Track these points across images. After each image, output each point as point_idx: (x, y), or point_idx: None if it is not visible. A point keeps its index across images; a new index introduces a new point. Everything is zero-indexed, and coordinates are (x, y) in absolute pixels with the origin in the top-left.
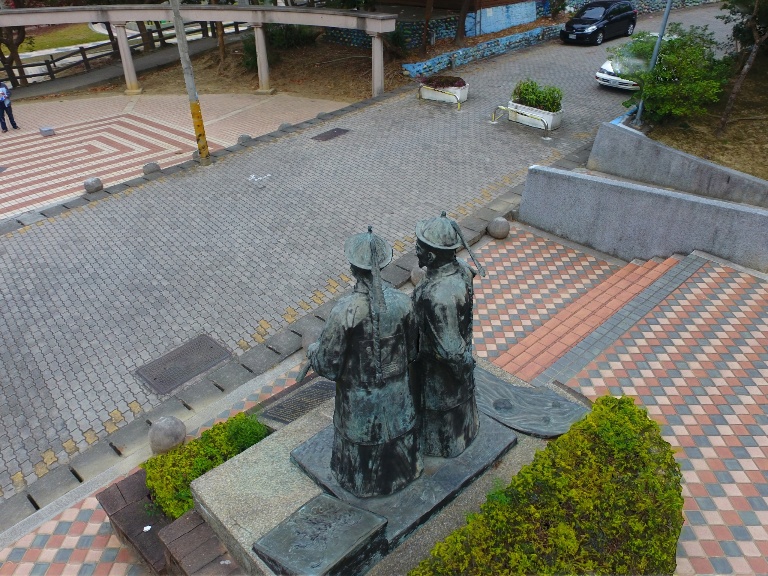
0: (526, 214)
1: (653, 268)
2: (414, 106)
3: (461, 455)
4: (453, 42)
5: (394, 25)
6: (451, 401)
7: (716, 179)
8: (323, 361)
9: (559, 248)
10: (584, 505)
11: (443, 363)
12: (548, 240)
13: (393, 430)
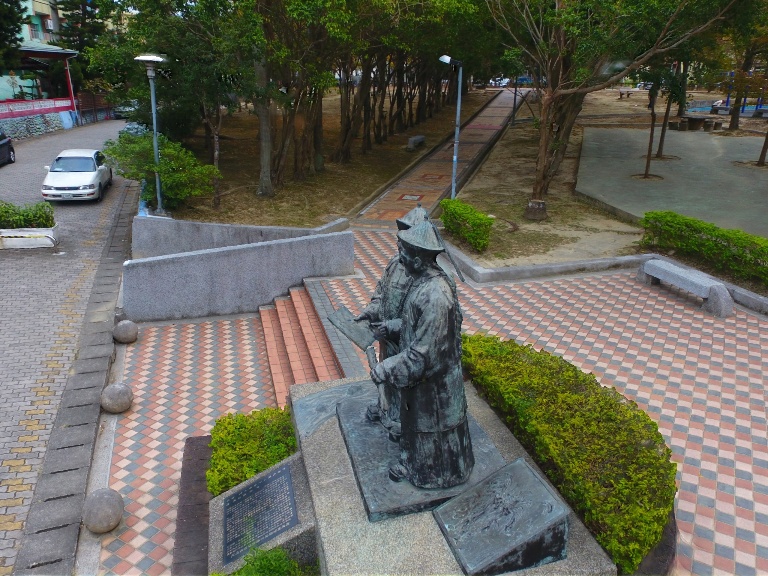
0: (135, 312)
1: (286, 304)
2: None
3: None
4: None
5: None
6: None
7: (253, 236)
8: (434, 354)
9: (192, 326)
10: (546, 382)
11: None
12: (174, 325)
13: None
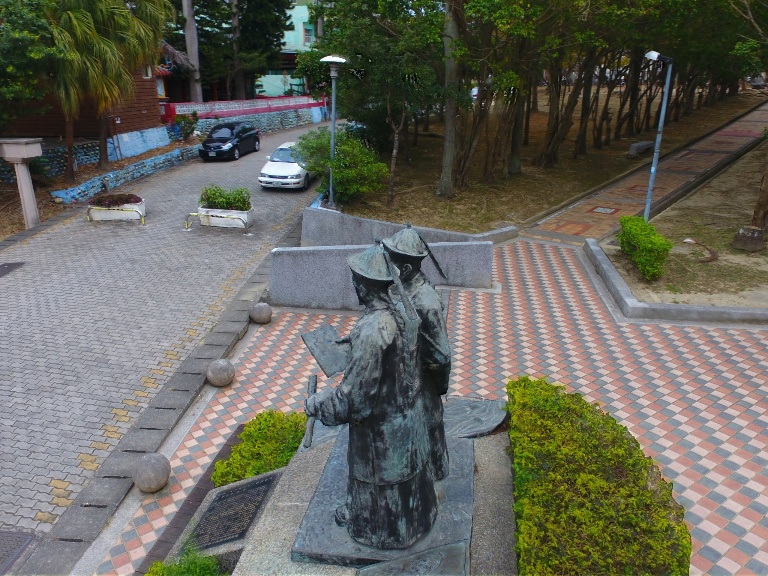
0: (278, 296)
1: None
2: (89, 229)
3: (450, 472)
4: (98, 167)
5: (40, 149)
6: (437, 415)
7: None
8: (359, 397)
9: (323, 317)
10: (579, 455)
11: (437, 372)
12: (308, 314)
13: (424, 453)
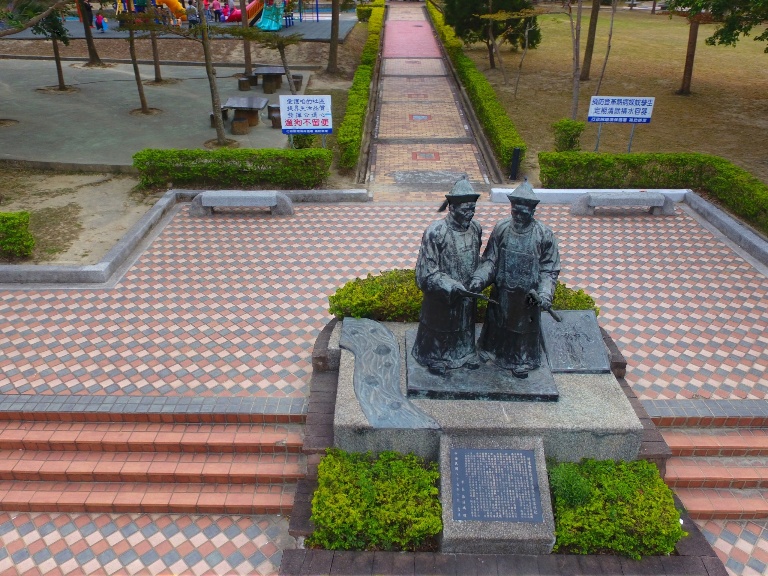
0: None
1: None
2: None
3: None
4: None
5: None
6: None
7: None
8: None
9: None
10: None
11: None
12: None
13: None
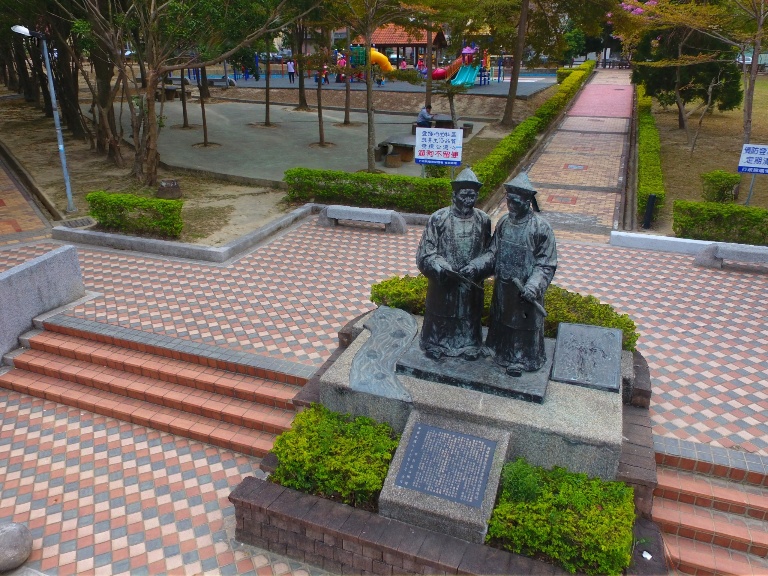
0: None
1: (36, 355)
2: None
3: None
4: None
5: None
6: None
7: None
8: None
9: None
10: None
11: None
12: None
13: None
